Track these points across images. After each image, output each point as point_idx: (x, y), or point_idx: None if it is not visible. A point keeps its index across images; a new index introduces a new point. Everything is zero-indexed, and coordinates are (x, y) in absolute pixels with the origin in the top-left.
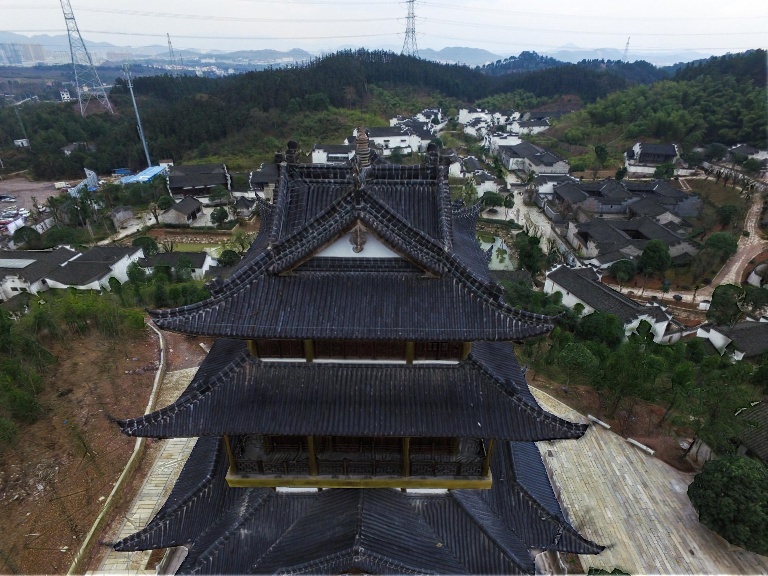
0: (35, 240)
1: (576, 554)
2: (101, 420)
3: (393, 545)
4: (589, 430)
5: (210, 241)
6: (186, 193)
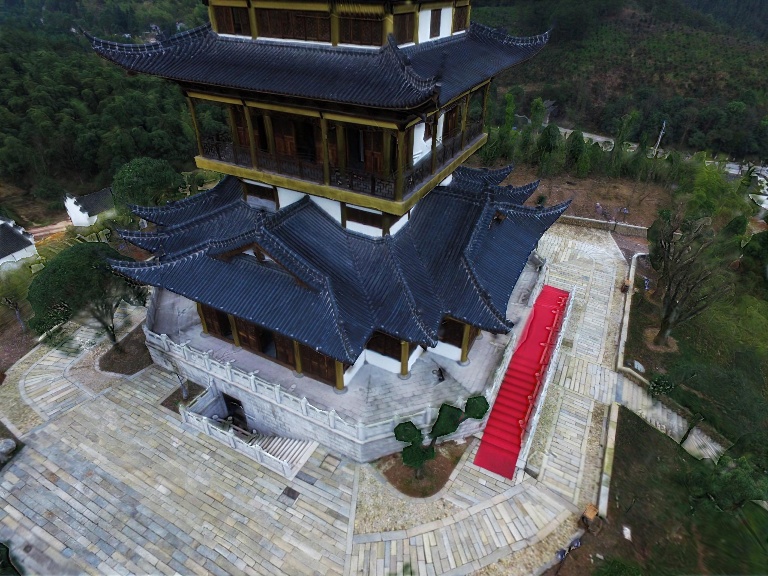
0: None
1: (177, 411)
2: None
3: None
4: None
5: None
6: None
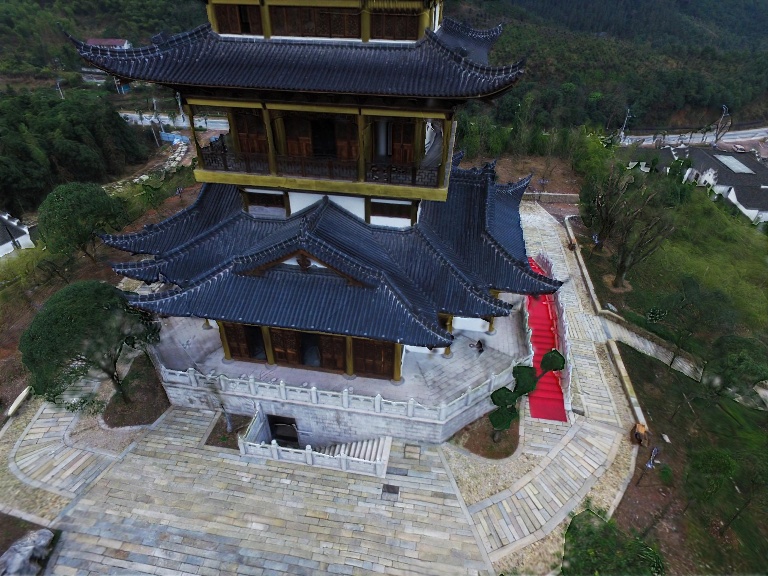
0: None
1: (229, 446)
2: None
3: (224, 189)
4: None
5: None
6: None
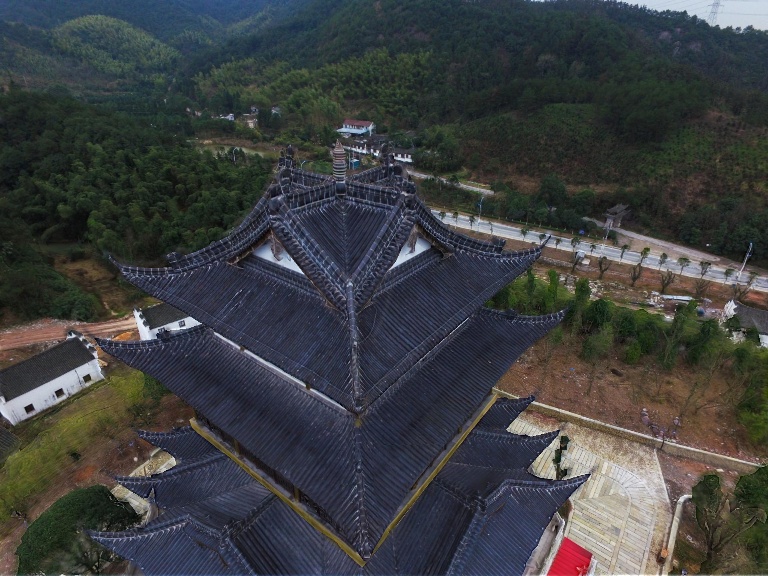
0: None
1: None
2: (565, 384)
3: None
4: None
5: None
6: None
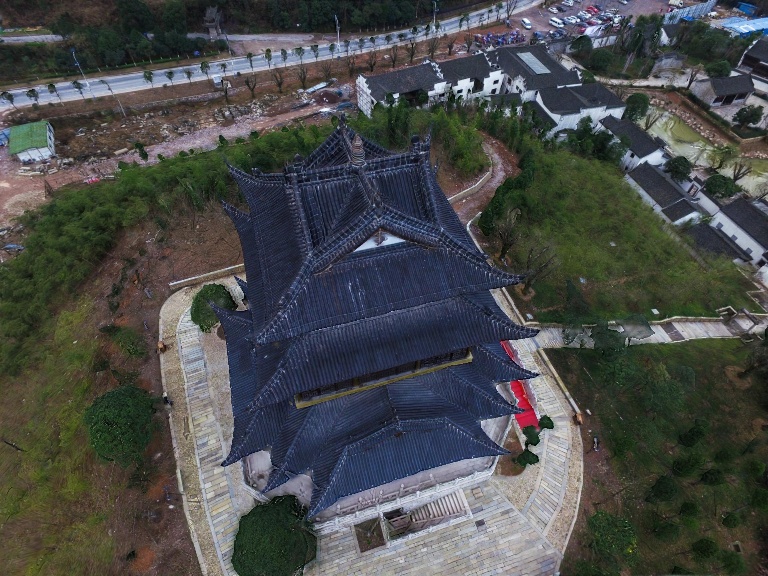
0: (586, 52)
1: (376, 546)
2: None
3: None
4: (537, 573)
5: (710, 137)
6: (758, 69)
